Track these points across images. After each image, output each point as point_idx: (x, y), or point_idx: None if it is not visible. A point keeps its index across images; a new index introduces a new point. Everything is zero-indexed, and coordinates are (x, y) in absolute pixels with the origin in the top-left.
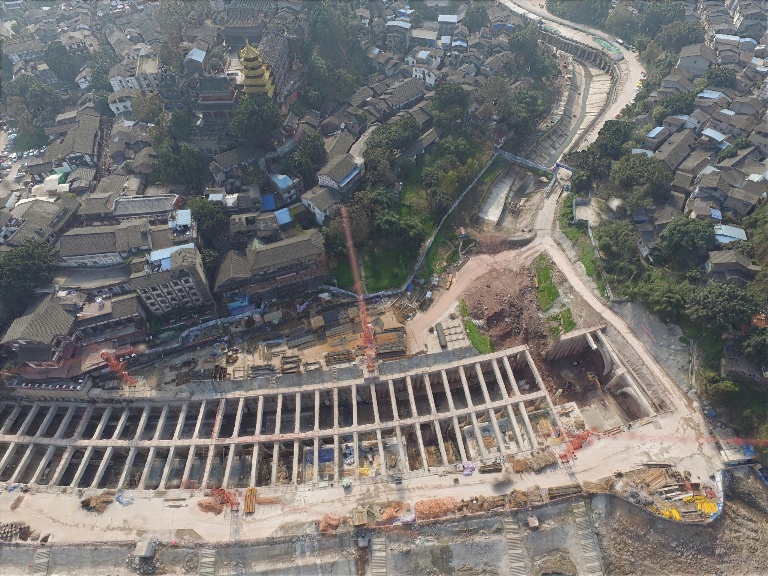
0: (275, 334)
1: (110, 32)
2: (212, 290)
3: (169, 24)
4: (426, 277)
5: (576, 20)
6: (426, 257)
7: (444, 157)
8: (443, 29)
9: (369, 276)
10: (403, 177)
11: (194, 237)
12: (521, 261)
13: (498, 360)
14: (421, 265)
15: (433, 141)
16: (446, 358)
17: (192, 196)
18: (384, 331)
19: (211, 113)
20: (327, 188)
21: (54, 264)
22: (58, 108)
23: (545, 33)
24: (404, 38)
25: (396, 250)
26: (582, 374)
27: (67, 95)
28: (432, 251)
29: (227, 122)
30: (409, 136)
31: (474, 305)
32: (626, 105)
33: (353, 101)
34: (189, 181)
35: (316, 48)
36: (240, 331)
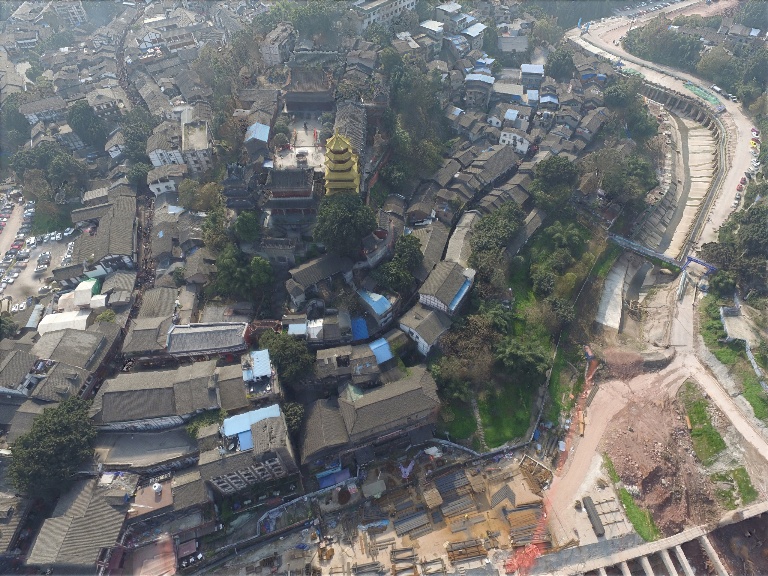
0: (378, 513)
1: (141, 82)
2: (299, 461)
3: (217, 83)
4: (553, 418)
5: (660, 61)
6: (549, 389)
7: (549, 246)
8: (526, 81)
9: (487, 424)
10: (508, 277)
11: (276, 393)
12: (663, 390)
13: (669, 550)
14: (545, 401)
15: (537, 228)
16: (603, 550)
17: (264, 323)
18: (517, 508)
19: (283, 210)
20: (434, 311)
21: (95, 434)
22: (84, 180)
23: (627, 77)
24: (486, 94)
25: (515, 383)
26: (760, 551)
27: (94, 164)
28: (555, 379)
29: (302, 221)
30: (516, 228)
31: (625, 465)
32: (746, 173)
33: (440, 179)
34: (257, 298)
35: (398, 118)
36: (333, 511)
